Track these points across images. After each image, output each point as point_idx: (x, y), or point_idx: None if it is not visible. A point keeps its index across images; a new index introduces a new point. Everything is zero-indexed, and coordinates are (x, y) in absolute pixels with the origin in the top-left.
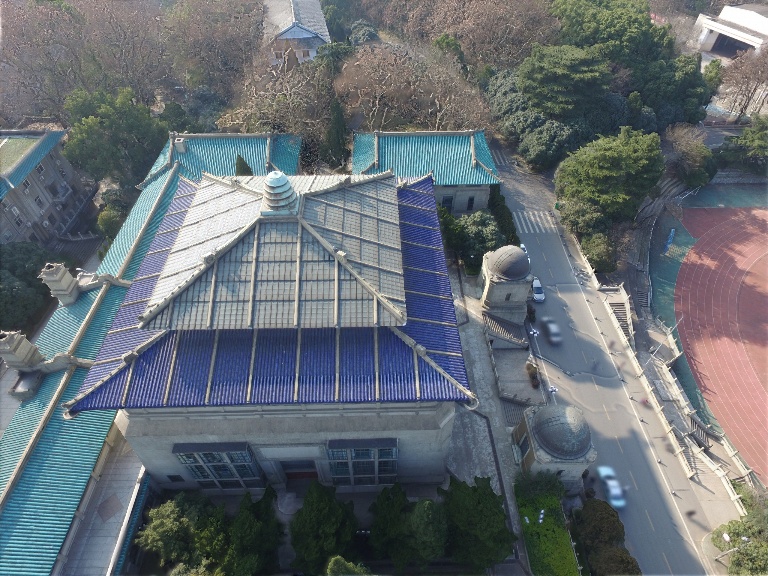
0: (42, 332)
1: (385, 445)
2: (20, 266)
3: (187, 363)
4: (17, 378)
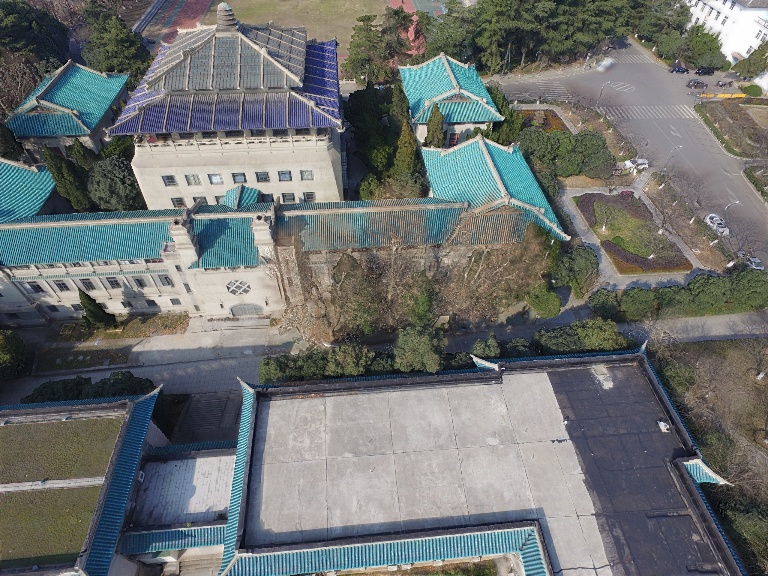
0: (227, 266)
1: (341, 97)
2: (76, 387)
3: (316, 93)
4: (281, 247)
